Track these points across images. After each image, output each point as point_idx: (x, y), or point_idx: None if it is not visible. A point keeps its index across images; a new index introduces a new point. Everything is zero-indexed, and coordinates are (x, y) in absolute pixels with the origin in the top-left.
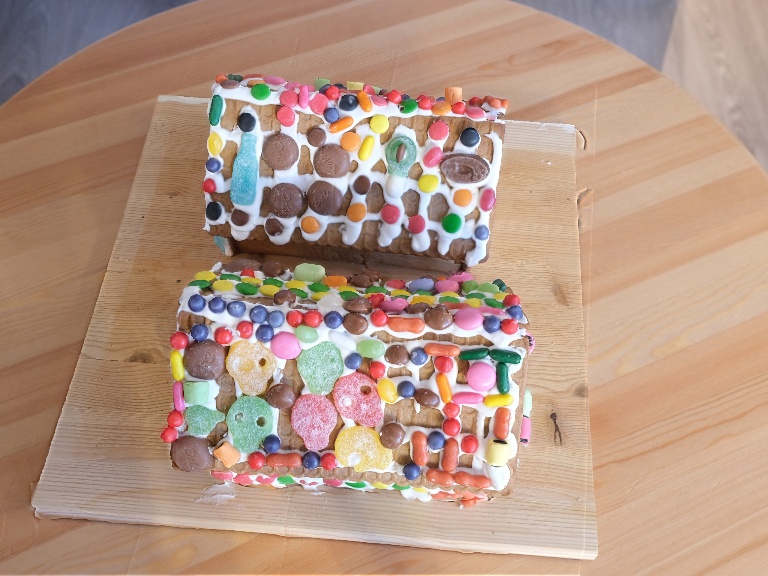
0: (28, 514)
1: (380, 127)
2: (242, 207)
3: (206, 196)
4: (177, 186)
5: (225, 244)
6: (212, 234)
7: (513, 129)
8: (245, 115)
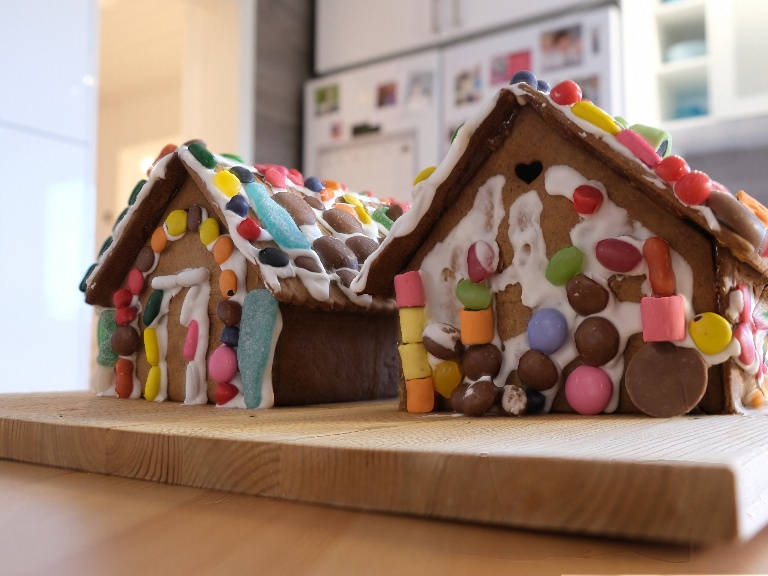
0: (737, 564)
1: (358, 200)
2: (306, 250)
3: (249, 245)
4: (62, 408)
5: (268, 368)
6: (285, 294)
7: None
8: (237, 167)
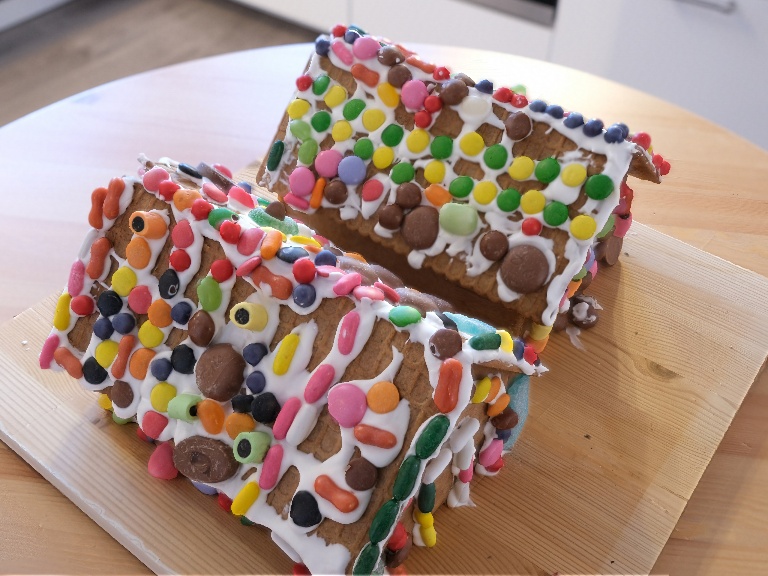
0: None
1: None
2: None
3: None
4: None
5: None
6: None
7: (4, 406)
8: (445, 319)
